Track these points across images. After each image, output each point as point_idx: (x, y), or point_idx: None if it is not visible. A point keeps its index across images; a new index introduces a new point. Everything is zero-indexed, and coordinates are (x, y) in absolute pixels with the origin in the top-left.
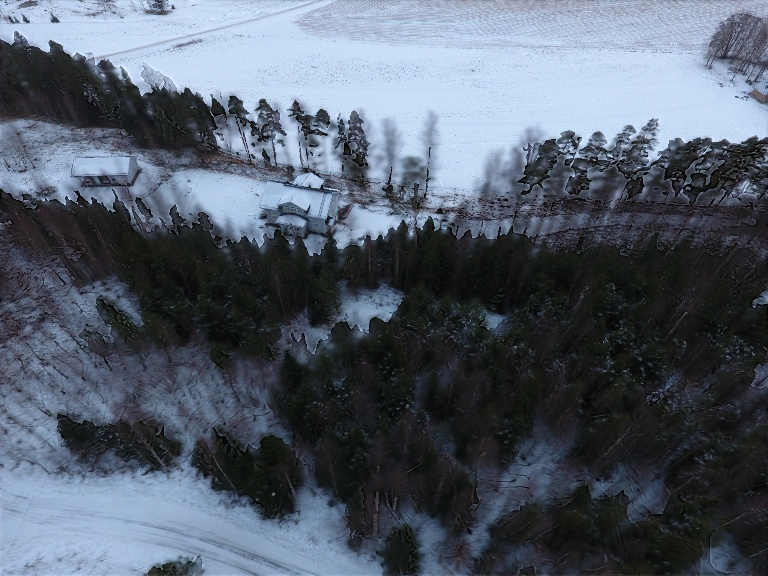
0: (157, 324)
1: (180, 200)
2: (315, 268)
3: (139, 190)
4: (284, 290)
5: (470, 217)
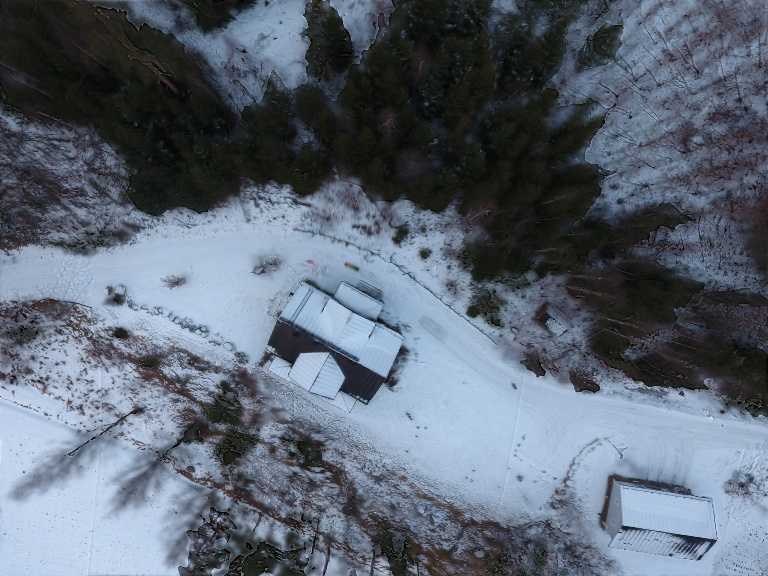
0: (542, 0)
1: (532, 427)
2: (331, 112)
3: (598, 463)
4: (377, 39)
5: (76, 315)
